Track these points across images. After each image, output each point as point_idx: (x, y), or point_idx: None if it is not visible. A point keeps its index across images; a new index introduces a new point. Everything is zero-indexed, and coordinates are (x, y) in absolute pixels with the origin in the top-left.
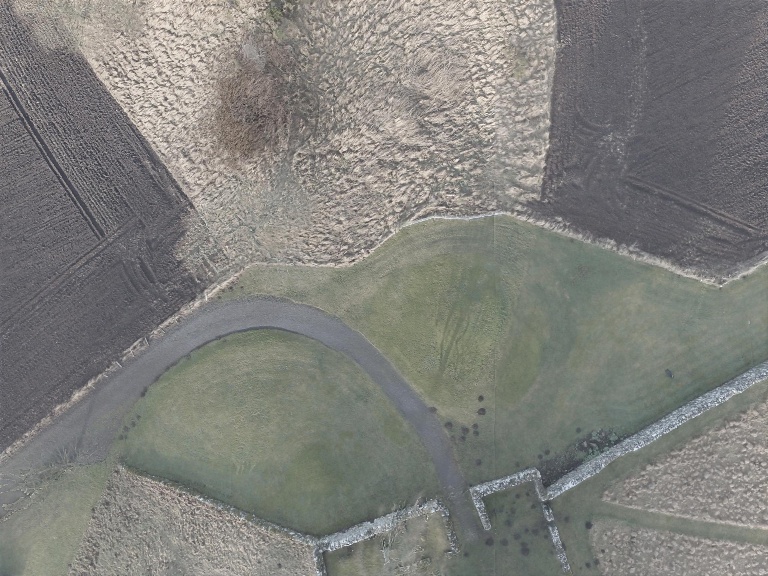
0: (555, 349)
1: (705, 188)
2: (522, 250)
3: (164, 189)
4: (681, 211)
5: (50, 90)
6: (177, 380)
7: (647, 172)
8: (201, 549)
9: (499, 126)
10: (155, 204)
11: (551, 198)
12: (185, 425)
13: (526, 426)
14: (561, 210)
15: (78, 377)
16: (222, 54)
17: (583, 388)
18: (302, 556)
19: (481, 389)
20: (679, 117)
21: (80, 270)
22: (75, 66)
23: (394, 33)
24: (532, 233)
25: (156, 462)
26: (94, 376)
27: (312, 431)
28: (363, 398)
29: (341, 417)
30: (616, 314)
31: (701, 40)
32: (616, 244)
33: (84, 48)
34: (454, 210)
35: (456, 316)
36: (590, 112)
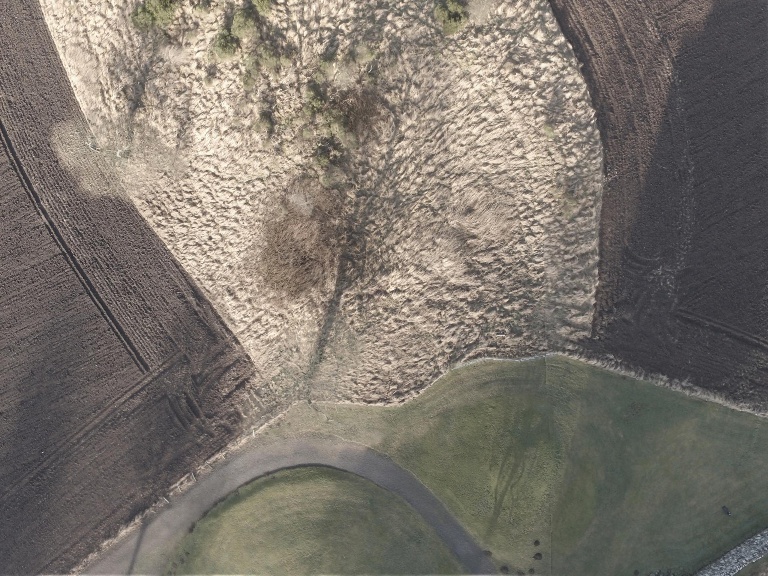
0: (610, 490)
1: (757, 319)
2: (574, 390)
3: (209, 324)
4: (733, 344)
5: (92, 226)
6: (226, 517)
7: (698, 305)
8: None
9: (548, 265)
10: (200, 340)
11: (602, 335)
12: (235, 564)
13: (583, 571)
14: (612, 346)
15: (125, 512)
16: (268, 198)
17: (640, 529)
18: None
19: (537, 534)
20: (728, 247)
21: (125, 404)
22: (117, 202)
23: (440, 173)
24: (584, 372)
25: None
26: (141, 511)
27: (365, 575)
28: (416, 539)
29: (394, 559)
30: (671, 451)
31: (748, 168)
32: (669, 379)
33: (126, 185)
34: (505, 351)
35: (510, 462)
36: (639, 246)
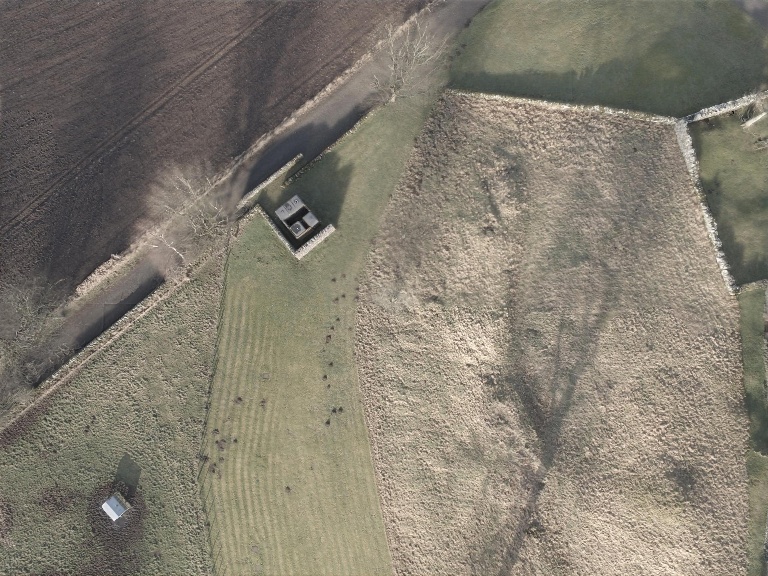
0: None
1: None
2: None
3: None
4: None
5: None
6: (505, 5)
7: None
8: (542, 153)
9: None
10: None
11: None
12: (517, 44)
13: None
14: None
15: (398, 15)
16: None
17: None
18: (658, 138)
19: None
20: None
21: None
22: None
23: None
24: None
25: (486, 83)
26: (415, 12)
27: (656, 32)
28: (701, 5)
29: (682, 21)
30: None
31: None
32: None
33: None
34: None
35: None
36: None
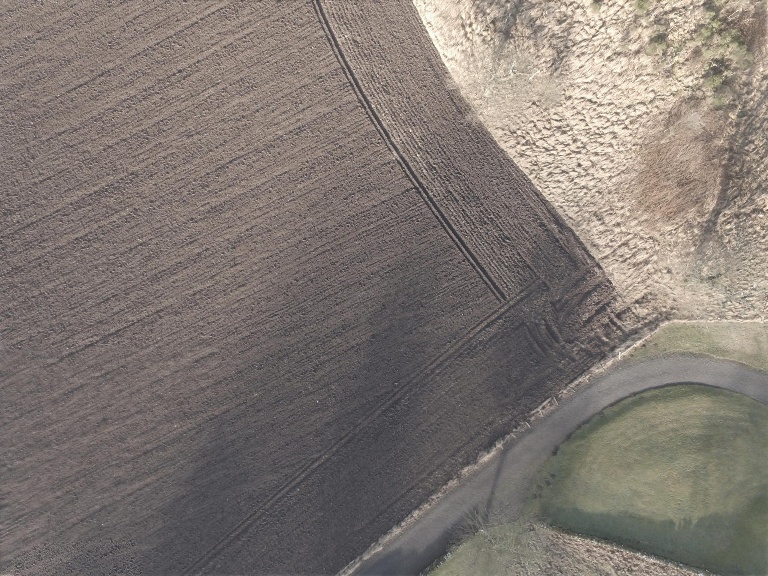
0: None
1: None
2: None
3: (569, 251)
4: None
5: (447, 159)
6: (594, 438)
7: None
8: None
9: None
10: (561, 266)
11: None
12: (609, 483)
13: None
14: None
15: (483, 438)
16: (650, 121)
17: None
18: None
19: None
20: None
21: (481, 333)
22: (474, 135)
23: None
24: None
25: (579, 520)
26: (500, 437)
27: (754, 485)
28: None
29: None
30: None
31: None
32: None
33: (485, 118)
34: None
35: None
36: None
